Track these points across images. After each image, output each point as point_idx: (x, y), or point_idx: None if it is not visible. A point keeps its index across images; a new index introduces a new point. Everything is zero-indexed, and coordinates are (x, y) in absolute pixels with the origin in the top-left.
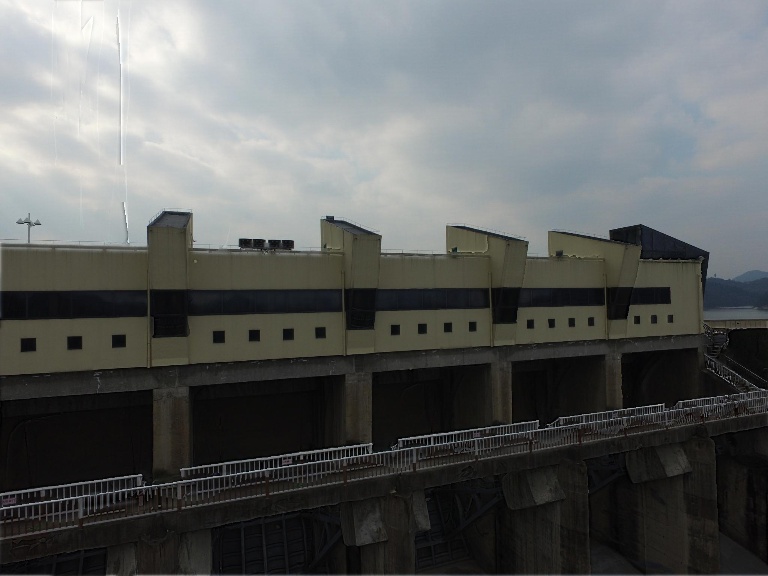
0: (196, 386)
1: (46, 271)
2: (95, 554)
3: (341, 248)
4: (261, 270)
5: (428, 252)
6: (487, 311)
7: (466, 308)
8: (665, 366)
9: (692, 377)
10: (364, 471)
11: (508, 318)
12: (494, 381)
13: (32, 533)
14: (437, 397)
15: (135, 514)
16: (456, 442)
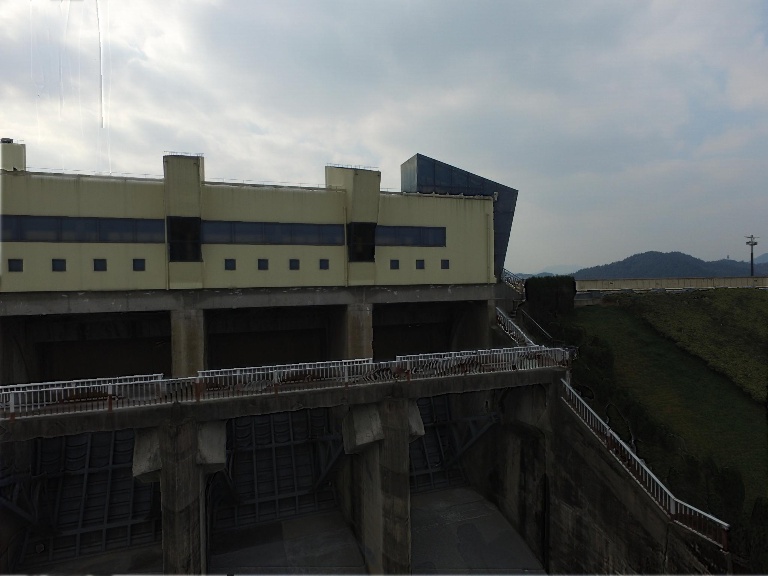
0: None
1: None
2: None
3: None
4: None
5: (69, 172)
6: (162, 247)
7: (129, 242)
8: (467, 324)
9: (484, 335)
10: None
11: (191, 256)
12: (175, 332)
13: None
14: None
15: None
16: None
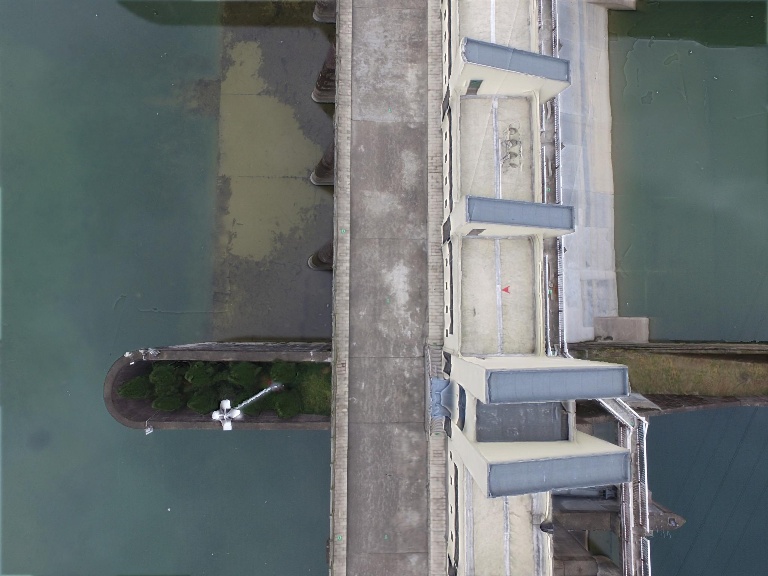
0: None
1: None
2: None
3: None
4: None
5: None
6: None
7: None
8: None
9: None
10: None
11: None
12: None
13: None
14: None
15: None
16: None
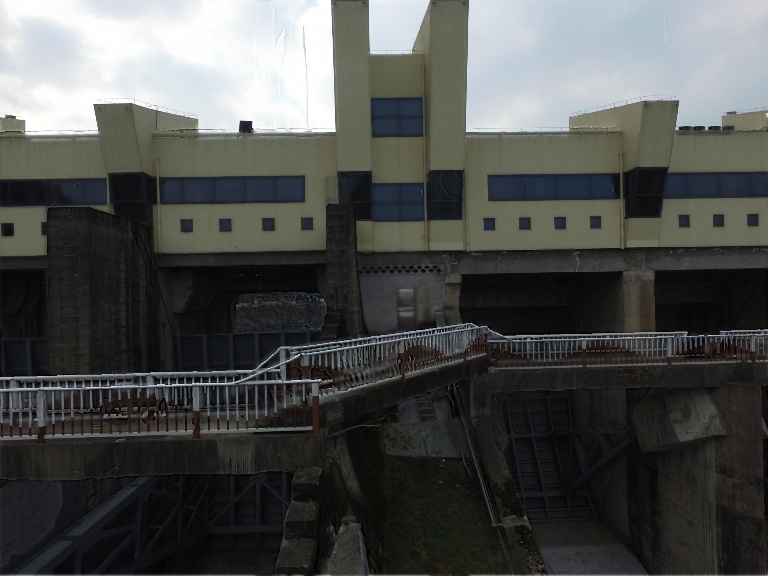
0: (660, 271)
1: (536, 156)
2: (522, 436)
3: None
4: (724, 151)
5: None
6: None
7: None
8: None
9: None
10: None
11: None
12: None
13: (631, 364)
14: None
15: (713, 360)
16: None
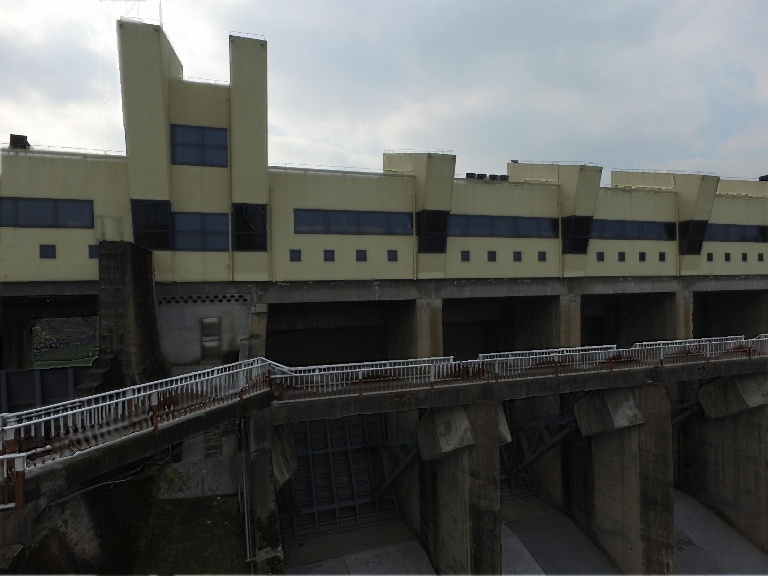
0: (447, 299)
1: (340, 193)
2: (339, 450)
3: (556, 181)
4: (496, 198)
5: (626, 187)
6: (674, 243)
7: (657, 240)
8: None
9: None
10: (625, 363)
11: (693, 250)
12: (678, 308)
13: (401, 390)
14: (595, 333)
15: (467, 382)
16: (692, 344)
